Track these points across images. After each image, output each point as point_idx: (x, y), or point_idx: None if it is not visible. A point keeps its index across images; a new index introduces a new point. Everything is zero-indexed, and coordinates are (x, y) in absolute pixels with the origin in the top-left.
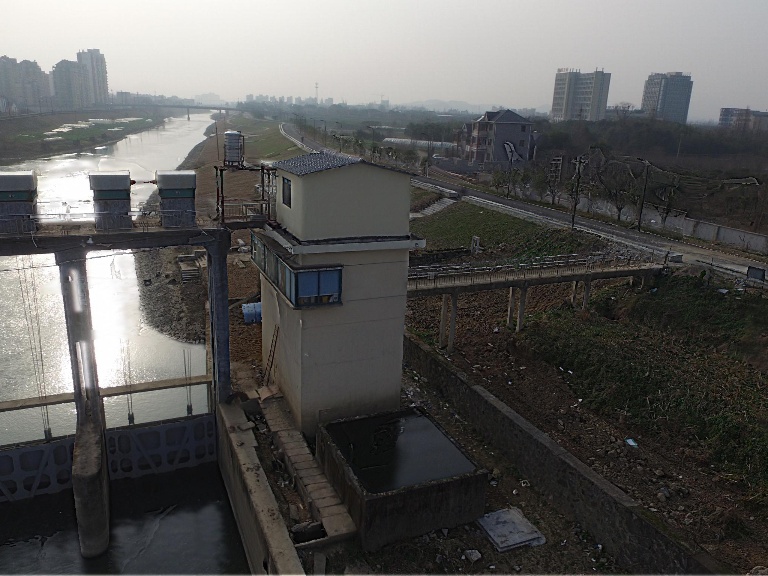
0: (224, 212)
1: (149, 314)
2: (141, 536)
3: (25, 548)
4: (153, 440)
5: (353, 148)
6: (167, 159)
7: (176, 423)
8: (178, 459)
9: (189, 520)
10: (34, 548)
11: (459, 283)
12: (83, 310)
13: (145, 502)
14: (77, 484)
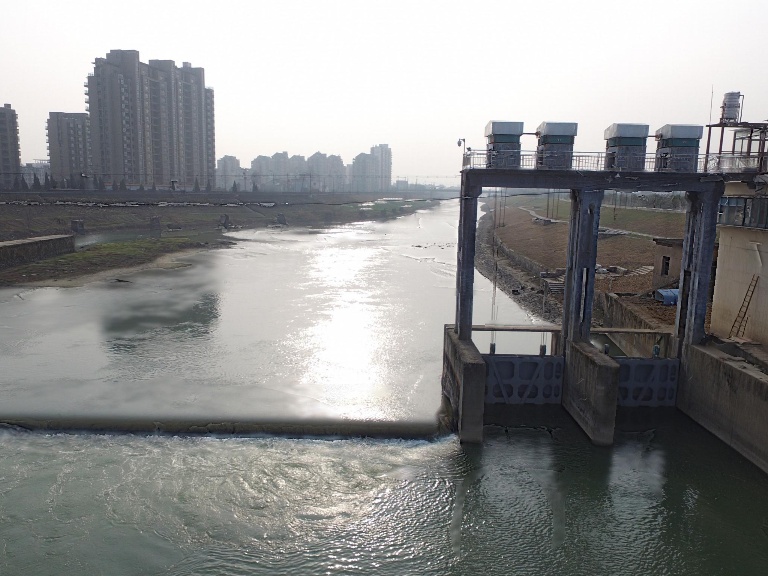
0: (719, 163)
1: (534, 311)
2: (636, 442)
3: (538, 432)
4: (622, 374)
5: (673, 202)
6: None
7: (646, 360)
8: (642, 396)
9: (681, 437)
10: (546, 433)
11: None
12: (594, 240)
13: (615, 427)
14: (604, 373)
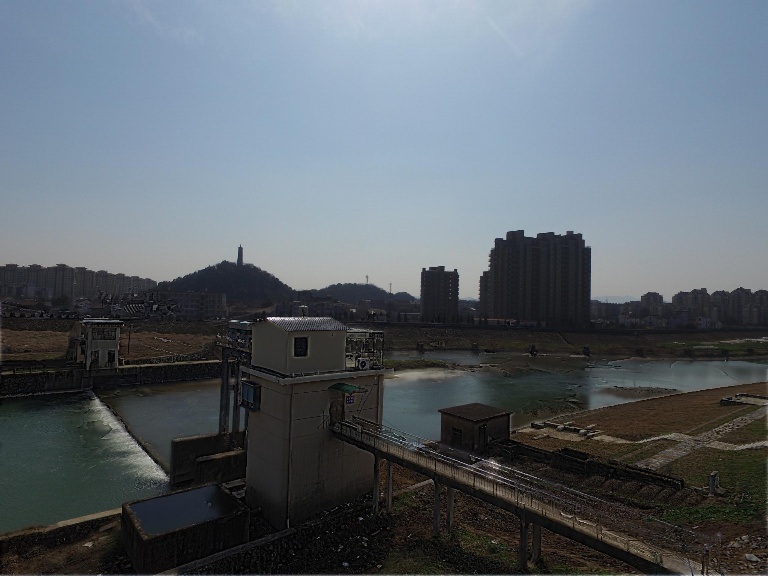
0: None
1: None
2: None
3: None
4: None
5: None
6: (765, 369)
7: None
8: None
9: None
10: None
11: (379, 446)
12: None
13: None
14: None
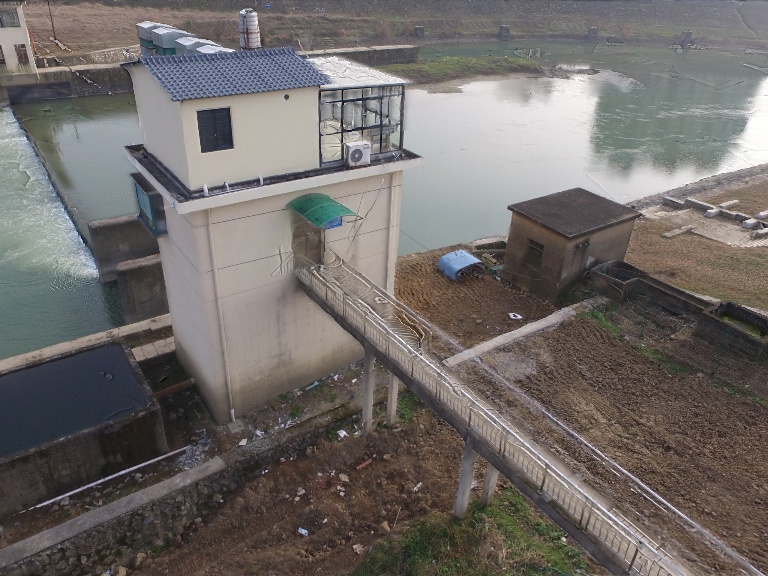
0: None
1: None
2: None
3: None
4: None
5: None
6: None
7: None
8: None
9: None
10: None
11: None
12: None
13: None
14: None
